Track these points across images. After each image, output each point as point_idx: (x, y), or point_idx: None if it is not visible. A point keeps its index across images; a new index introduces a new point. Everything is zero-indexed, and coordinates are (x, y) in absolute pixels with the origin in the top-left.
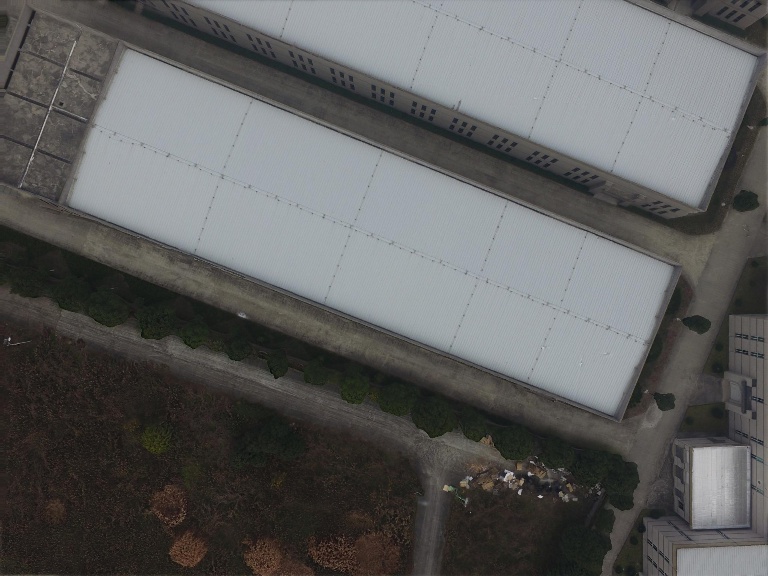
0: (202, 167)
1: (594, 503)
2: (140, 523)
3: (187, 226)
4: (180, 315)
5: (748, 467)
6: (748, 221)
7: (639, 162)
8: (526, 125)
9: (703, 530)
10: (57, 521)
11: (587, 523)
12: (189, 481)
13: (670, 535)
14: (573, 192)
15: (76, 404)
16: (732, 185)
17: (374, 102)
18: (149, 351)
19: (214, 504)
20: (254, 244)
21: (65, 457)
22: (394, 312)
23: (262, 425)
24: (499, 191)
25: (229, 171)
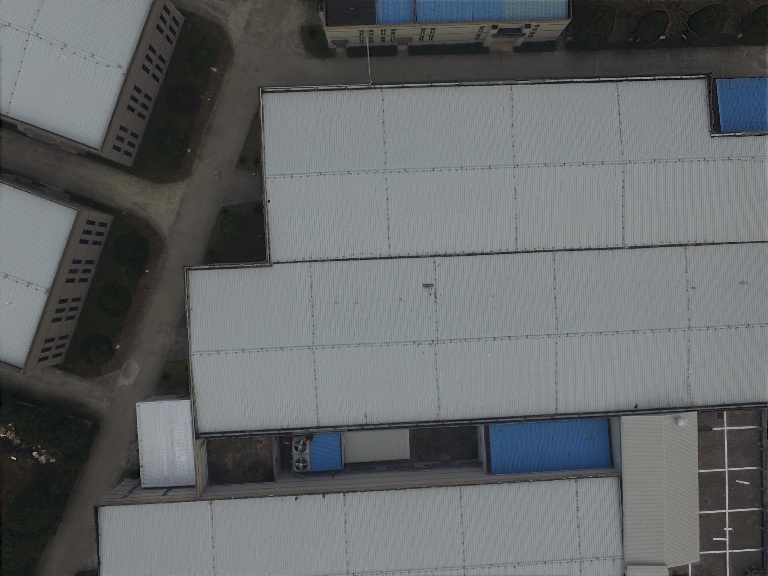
0: None
1: None
2: None
3: None
4: None
5: None
6: (220, 168)
7: (35, 103)
8: None
9: (153, 488)
10: None
11: None
12: None
13: (112, 493)
14: (30, 141)
15: None
16: (198, 130)
17: None
18: None
19: None
20: None
21: None
22: None
23: None
24: None
25: None
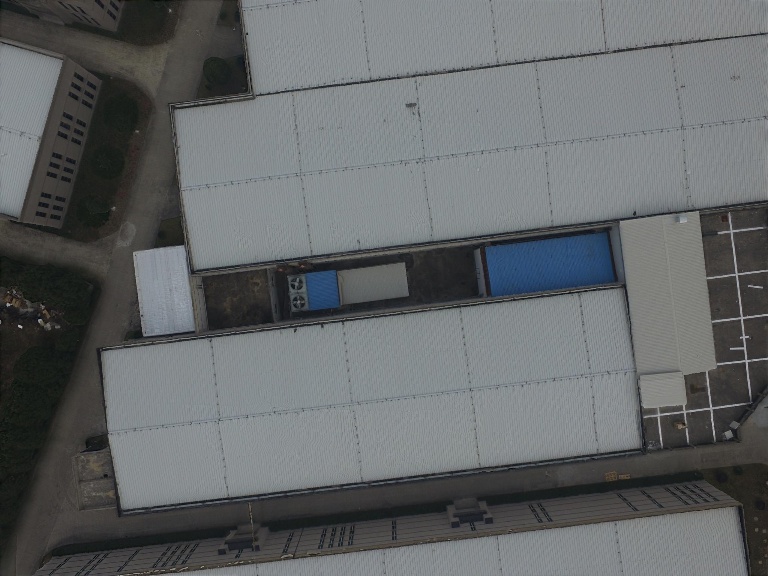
0: None
1: None
2: None
3: None
4: None
5: None
6: (201, 26)
7: None
8: None
9: (154, 336)
10: None
11: None
12: None
13: None
14: (19, 16)
15: None
16: None
17: None
18: None
19: None
20: None
21: None
22: None
23: None
24: None
25: None
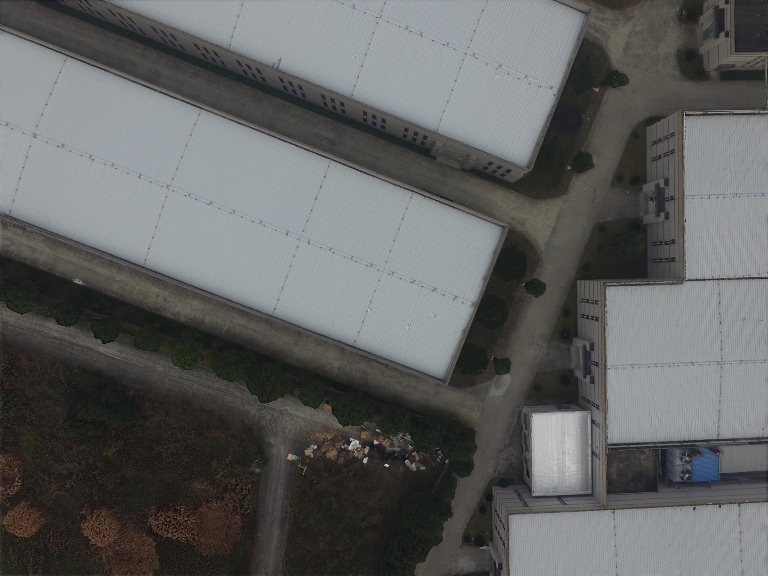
0: (14, 126)
1: (441, 472)
2: None
3: (1, 187)
4: (13, 281)
5: (589, 433)
6: (595, 185)
7: (465, 121)
8: (348, 83)
9: (543, 497)
10: None
11: (433, 492)
12: (27, 451)
13: (508, 502)
14: (415, 155)
15: None
16: (578, 148)
17: (209, 64)
18: None
19: (53, 474)
20: (70, 205)
21: None
22: (215, 274)
23: (95, 392)
24: (318, 150)
25: (41, 130)
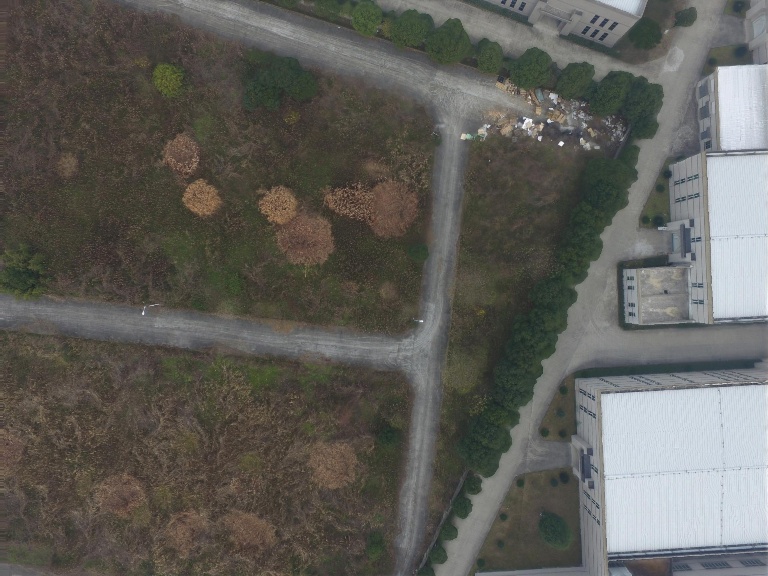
0: None
1: (617, 149)
2: (153, 174)
3: None
4: None
5: None
6: None
7: None
8: None
9: None
10: (69, 174)
11: None
12: (201, 134)
13: None
14: None
15: (87, 49)
16: None
17: None
18: (159, 1)
19: (227, 156)
20: None
21: (77, 104)
22: None
23: None
24: None
25: None
